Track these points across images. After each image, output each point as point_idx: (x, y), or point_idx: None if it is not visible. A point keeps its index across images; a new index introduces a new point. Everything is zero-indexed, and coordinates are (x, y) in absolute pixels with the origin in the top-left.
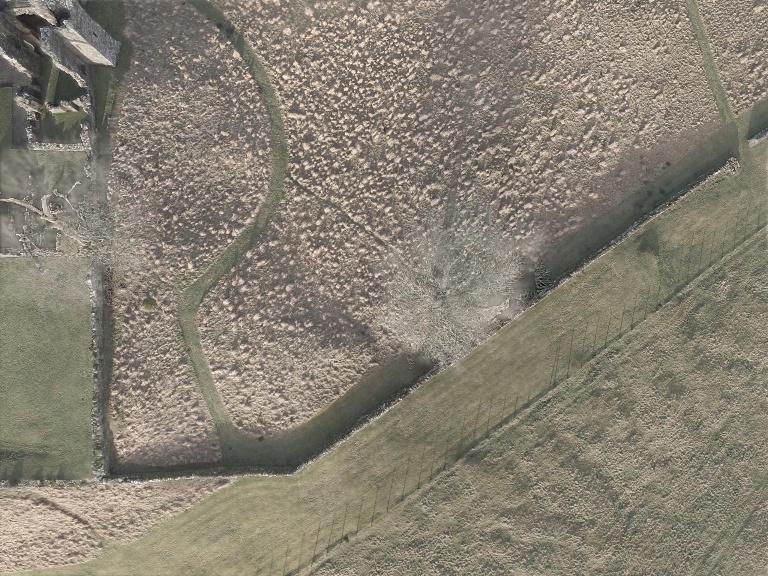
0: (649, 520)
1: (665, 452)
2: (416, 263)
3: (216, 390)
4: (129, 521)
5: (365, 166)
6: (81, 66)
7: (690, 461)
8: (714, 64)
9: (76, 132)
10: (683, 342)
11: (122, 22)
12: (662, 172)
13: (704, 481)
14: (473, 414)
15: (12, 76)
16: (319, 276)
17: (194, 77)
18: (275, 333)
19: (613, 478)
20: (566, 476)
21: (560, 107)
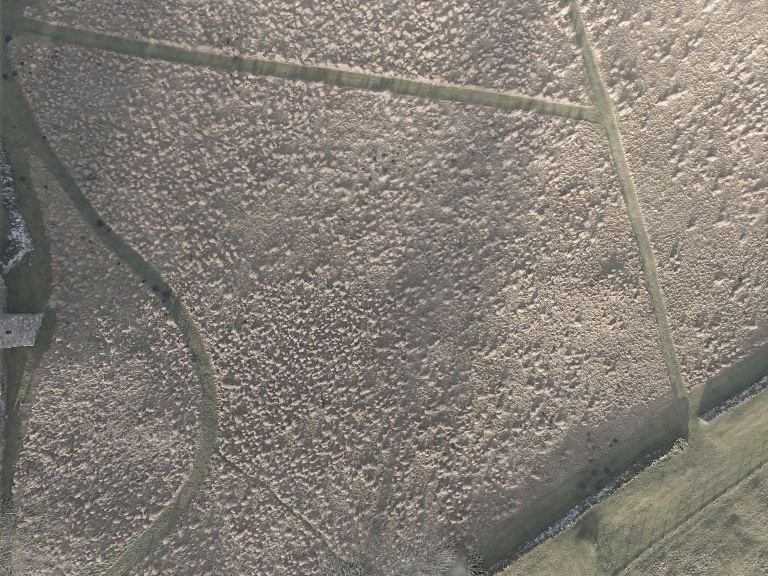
0: None
1: None
2: (344, 550)
3: None
4: None
5: (299, 444)
6: None
7: None
8: (670, 337)
9: None
10: None
11: (48, 289)
12: (608, 449)
13: None
14: None
15: None
16: (240, 561)
17: (121, 350)
18: None
19: None
20: None
21: (508, 383)
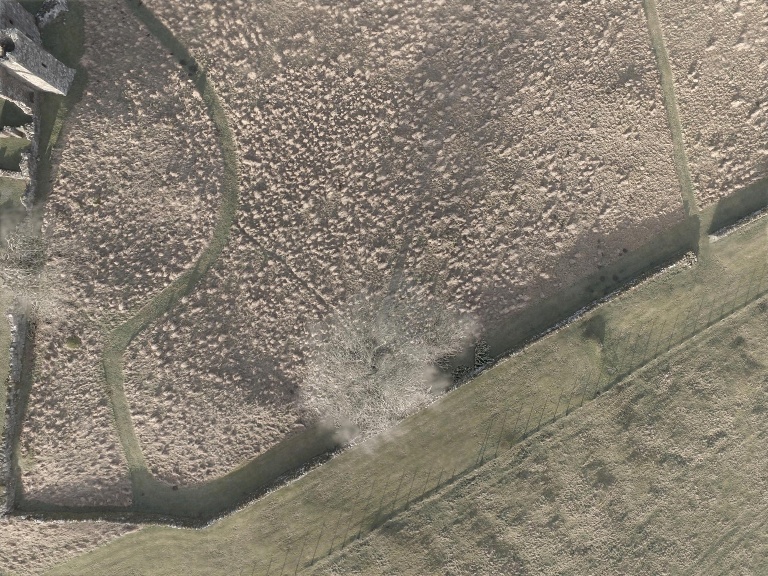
0: None
1: (586, 540)
2: (355, 326)
3: (134, 435)
4: (31, 556)
5: (315, 222)
6: (29, 93)
7: (610, 552)
8: (684, 155)
9: (18, 158)
10: (617, 432)
11: (80, 49)
12: (618, 258)
13: (622, 573)
14: (395, 485)
15: None
16: (254, 329)
17: (149, 113)
18: (202, 383)
19: (530, 562)
20: (482, 556)
21: (522, 182)
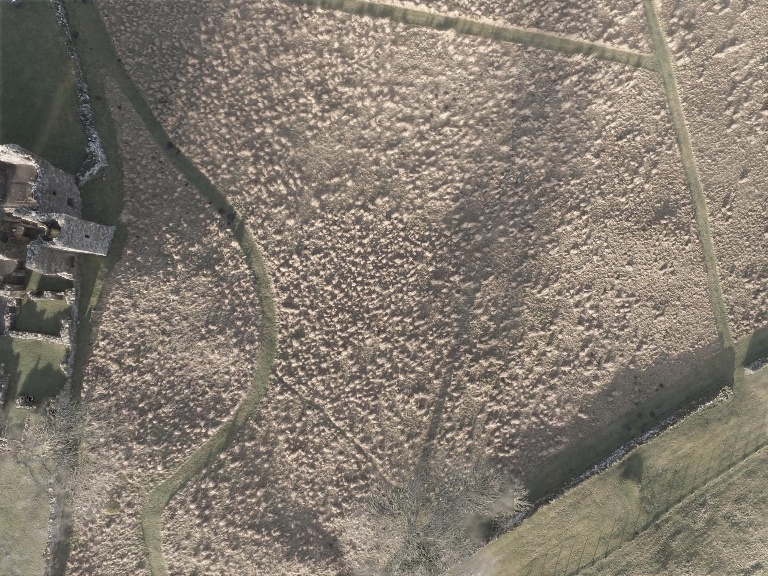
0: None
1: None
2: (394, 475)
3: None
4: None
5: (354, 369)
6: (70, 258)
7: None
8: (719, 287)
9: (57, 321)
10: (656, 571)
11: (120, 204)
12: (654, 394)
13: None
14: None
15: None
16: (293, 480)
17: (188, 267)
18: (240, 540)
19: None
20: None
21: (559, 322)
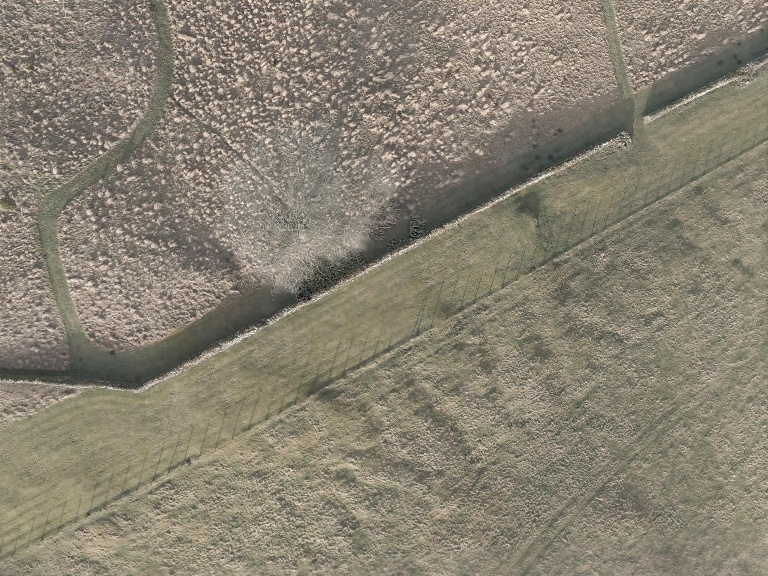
0: (499, 478)
1: (524, 413)
2: None
3: (71, 299)
4: None
5: (250, 95)
6: None
7: (548, 425)
8: (618, 38)
9: None
10: (554, 307)
11: None
12: (553, 138)
13: (560, 446)
14: (331, 353)
15: None
16: (190, 199)
17: None
18: (137, 249)
19: (468, 433)
20: (419, 425)
21: (456, 61)
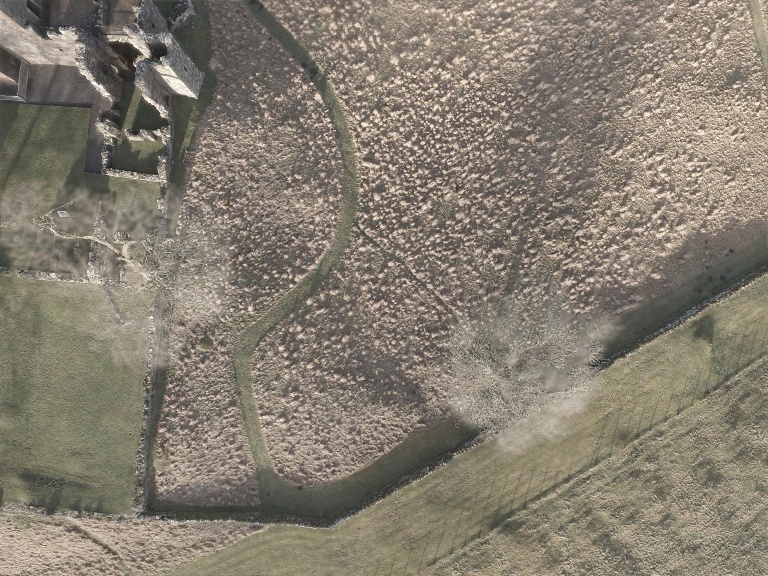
0: None
1: (695, 539)
2: (474, 327)
3: (262, 435)
4: (159, 556)
5: (434, 223)
6: (165, 96)
7: (719, 550)
8: None
9: (151, 161)
10: (726, 431)
11: (208, 52)
12: (725, 259)
13: (730, 571)
14: (513, 484)
15: (92, 97)
16: (376, 330)
17: (274, 116)
18: (327, 384)
19: (642, 560)
20: (597, 554)
21: (633, 184)
